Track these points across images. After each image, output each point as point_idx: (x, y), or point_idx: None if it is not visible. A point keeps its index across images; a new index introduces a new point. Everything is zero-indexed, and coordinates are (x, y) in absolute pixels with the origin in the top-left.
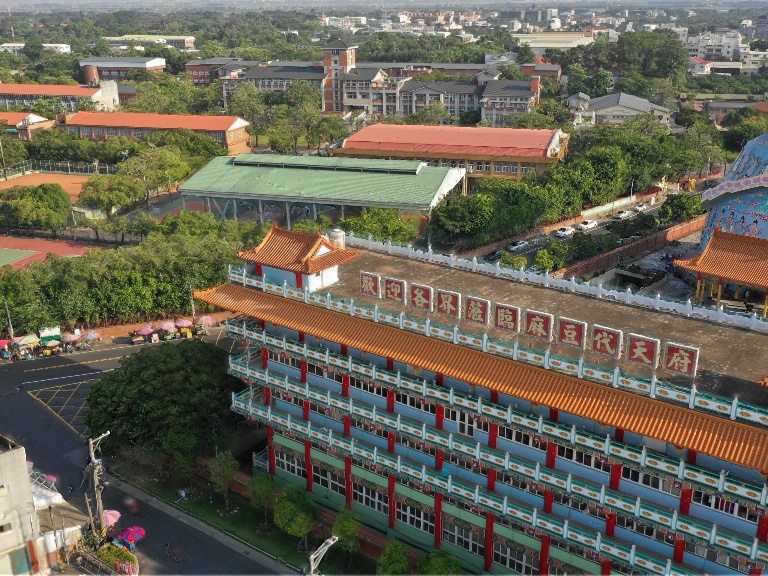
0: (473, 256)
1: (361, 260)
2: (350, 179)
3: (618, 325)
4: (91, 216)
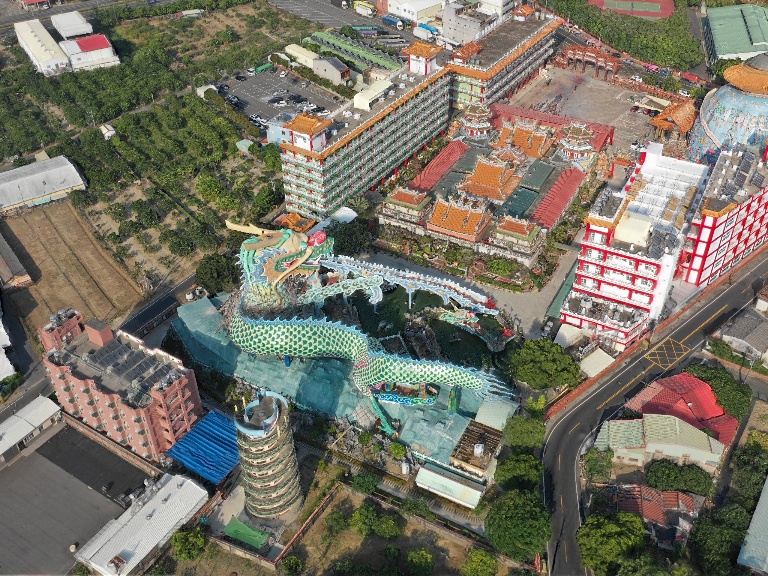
0: (716, 87)
1: (540, 22)
2: (738, 34)
3: (505, 44)
4: (705, 9)
